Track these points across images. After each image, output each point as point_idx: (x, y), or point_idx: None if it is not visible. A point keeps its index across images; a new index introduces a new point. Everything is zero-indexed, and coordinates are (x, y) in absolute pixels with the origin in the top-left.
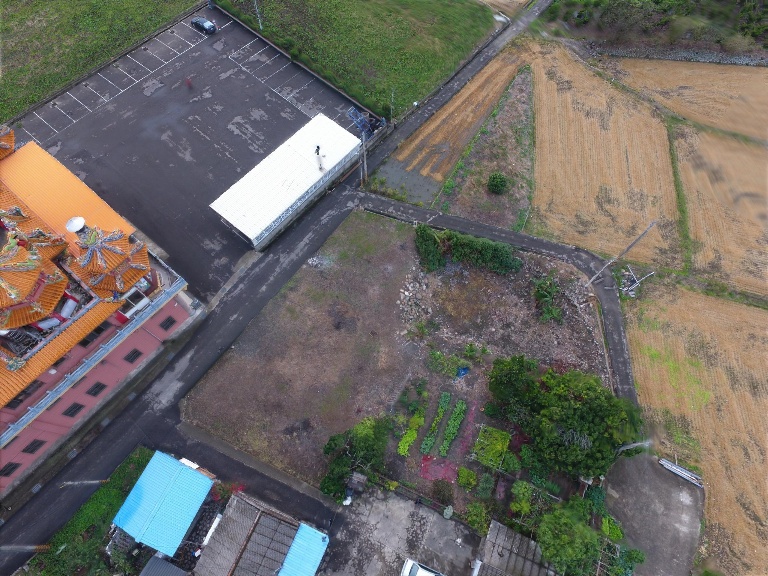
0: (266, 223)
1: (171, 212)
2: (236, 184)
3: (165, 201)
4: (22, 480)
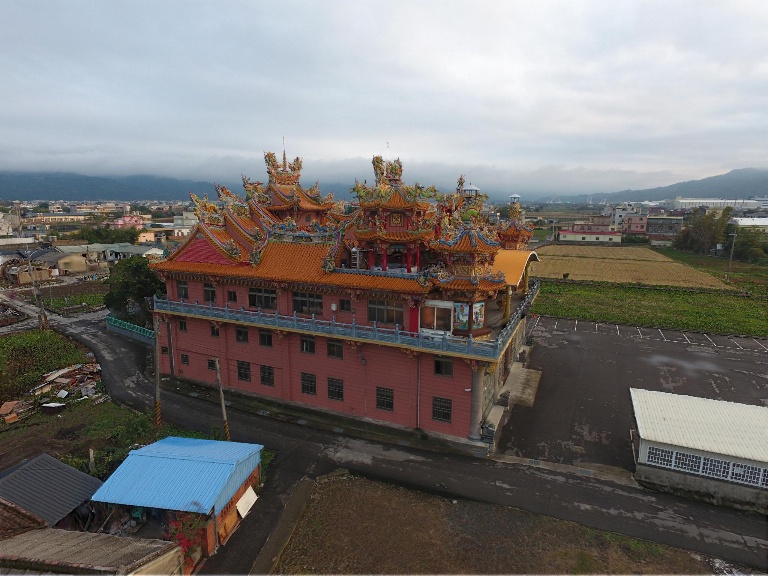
0: (689, 443)
1: (586, 393)
2: (696, 398)
3: (593, 387)
4: (236, 392)
